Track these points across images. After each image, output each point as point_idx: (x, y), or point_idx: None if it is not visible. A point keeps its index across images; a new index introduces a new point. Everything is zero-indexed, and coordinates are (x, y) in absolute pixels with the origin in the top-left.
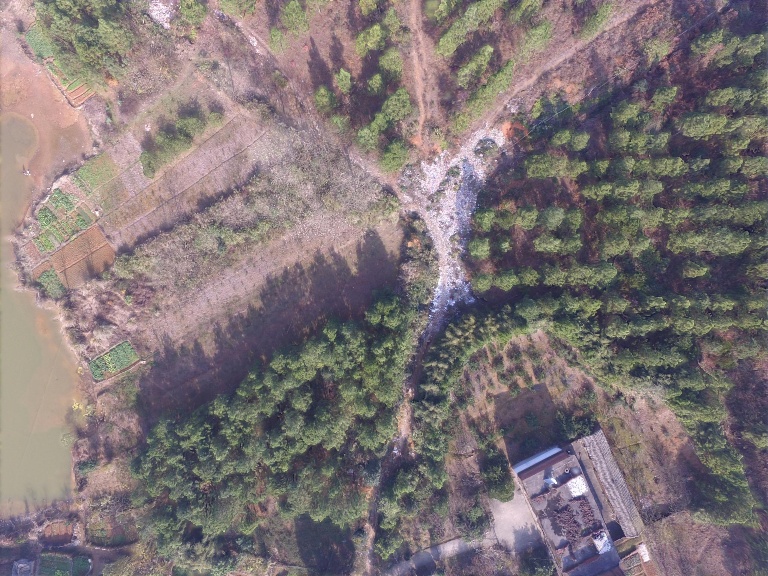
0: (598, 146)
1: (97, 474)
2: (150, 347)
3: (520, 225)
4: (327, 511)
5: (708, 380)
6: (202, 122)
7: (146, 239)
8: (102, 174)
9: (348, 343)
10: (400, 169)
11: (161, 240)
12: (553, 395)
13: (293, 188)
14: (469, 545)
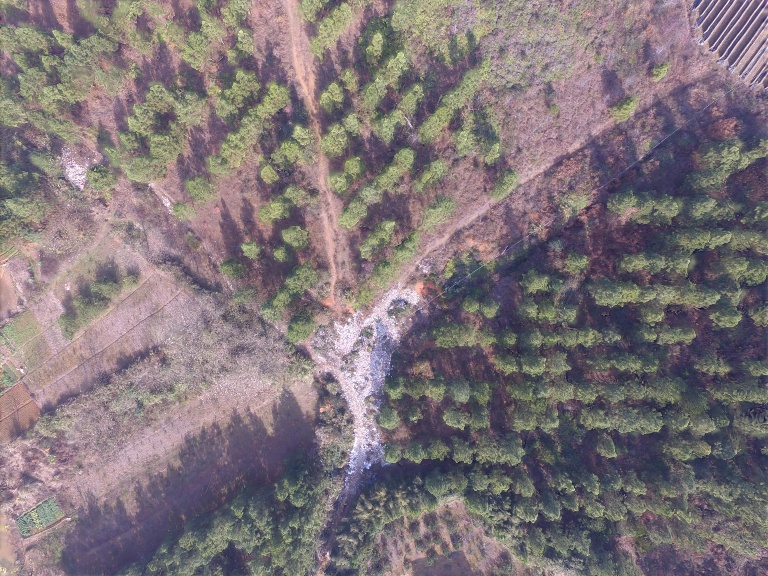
0: (514, 306)
1: None
2: (75, 504)
3: (430, 396)
4: None
5: (620, 571)
6: (119, 283)
7: (68, 398)
8: (26, 332)
9: (255, 521)
10: (313, 330)
11: (80, 402)
12: (471, 563)
13: (208, 349)
14: None
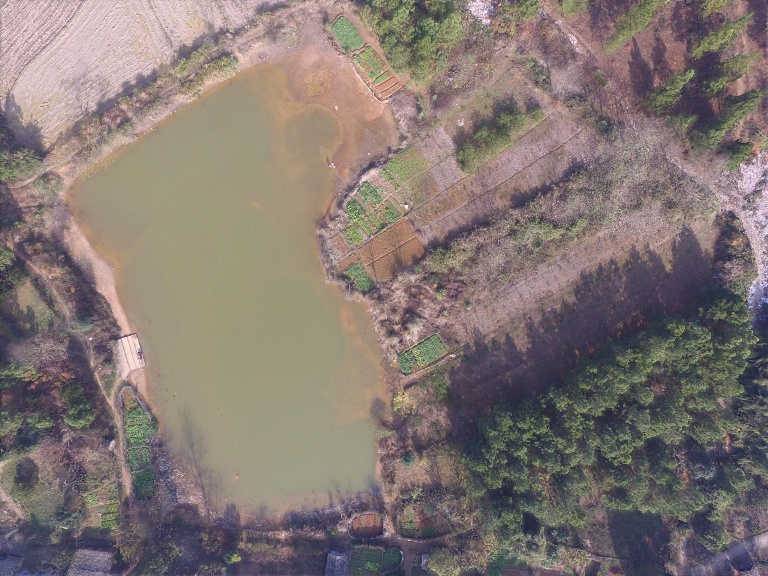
0: None
1: (405, 466)
2: (460, 341)
3: None
4: None
5: None
6: None
7: (458, 233)
8: (412, 168)
9: (695, 338)
10: (718, 169)
11: (480, 235)
12: None
13: (611, 186)
14: None
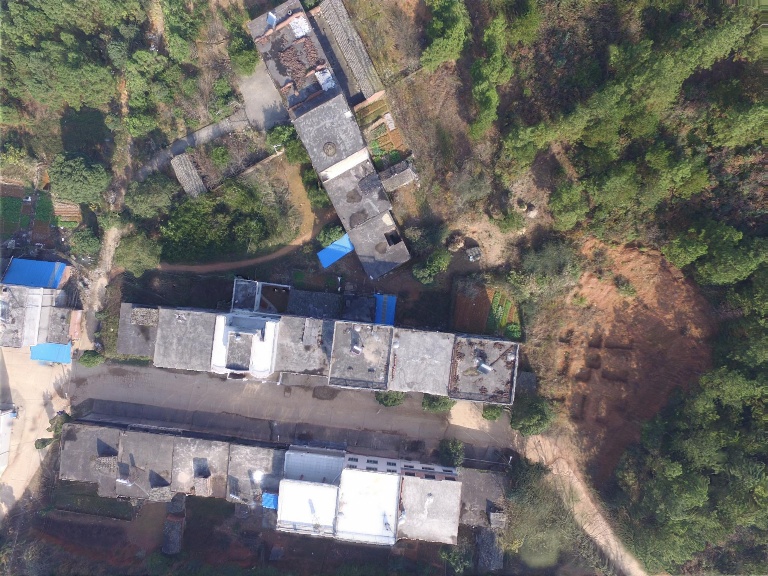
0: None
1: None
2: None
3: None
4: (62, 68)
5: None
6: None
7: None
8: None
9: None
10: None
11: None
12: None
13: None
14: (222, 129)
